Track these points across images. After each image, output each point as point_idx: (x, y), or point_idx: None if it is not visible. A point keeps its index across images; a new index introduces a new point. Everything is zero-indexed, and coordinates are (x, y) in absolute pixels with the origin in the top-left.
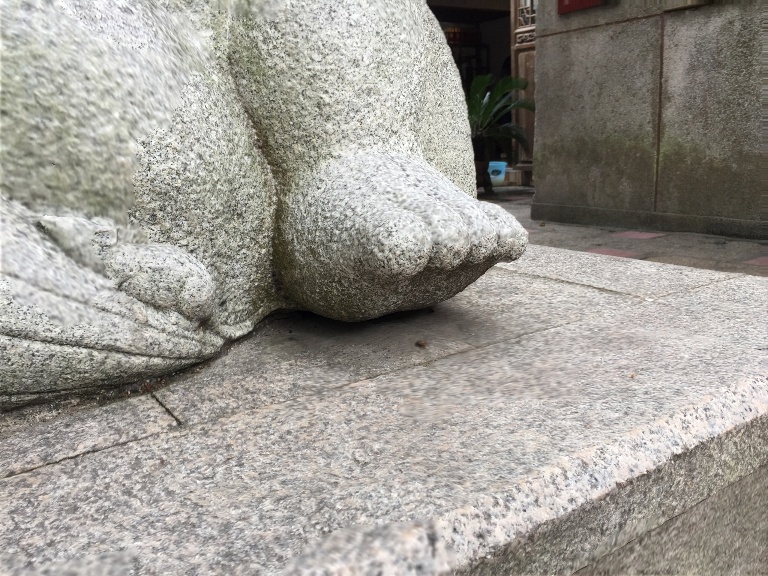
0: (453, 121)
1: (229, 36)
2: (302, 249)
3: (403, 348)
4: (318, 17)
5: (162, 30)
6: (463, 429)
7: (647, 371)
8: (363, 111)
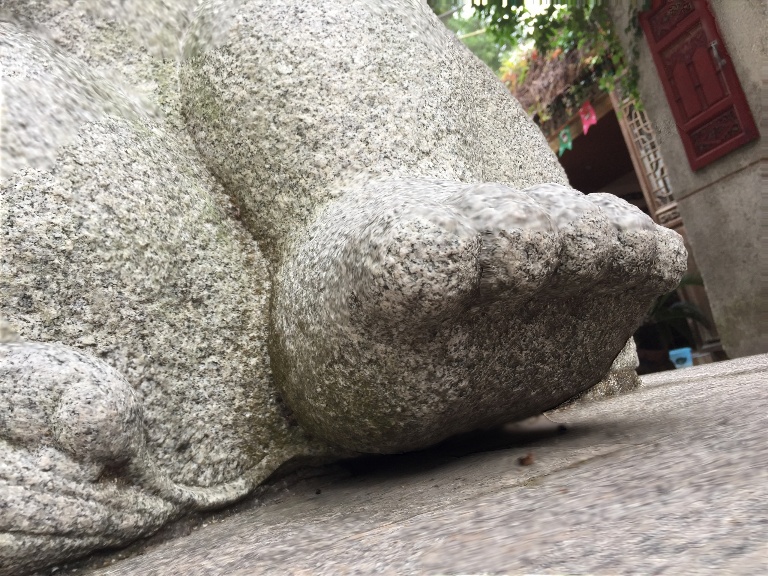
0: None
1: (180, 87)
2: (291, 330)
3: (490, 471)
4: (280, 22)
5: (63, 70)
6: (573, 570)
7: None
8: (367, 127)
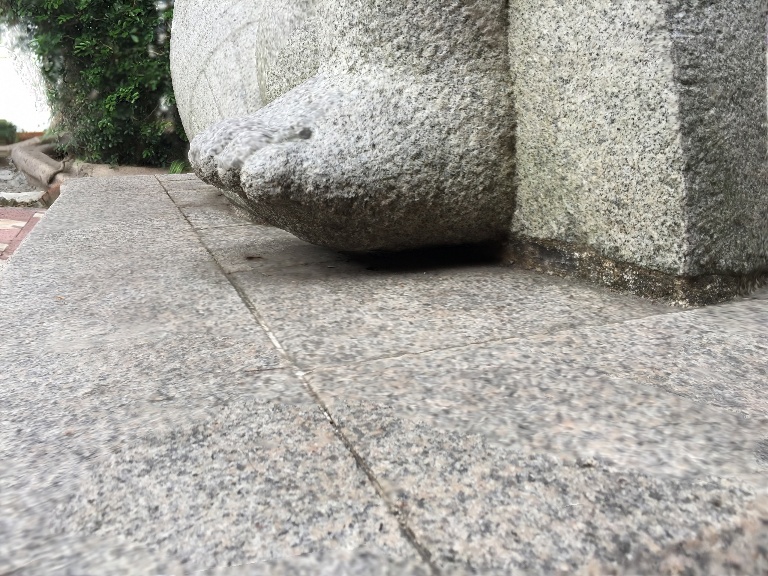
0: (612, 6)
1: None
2: None
3: None
4: None
5: None
6: (86, 258)
7: (58, 304)
8: None
